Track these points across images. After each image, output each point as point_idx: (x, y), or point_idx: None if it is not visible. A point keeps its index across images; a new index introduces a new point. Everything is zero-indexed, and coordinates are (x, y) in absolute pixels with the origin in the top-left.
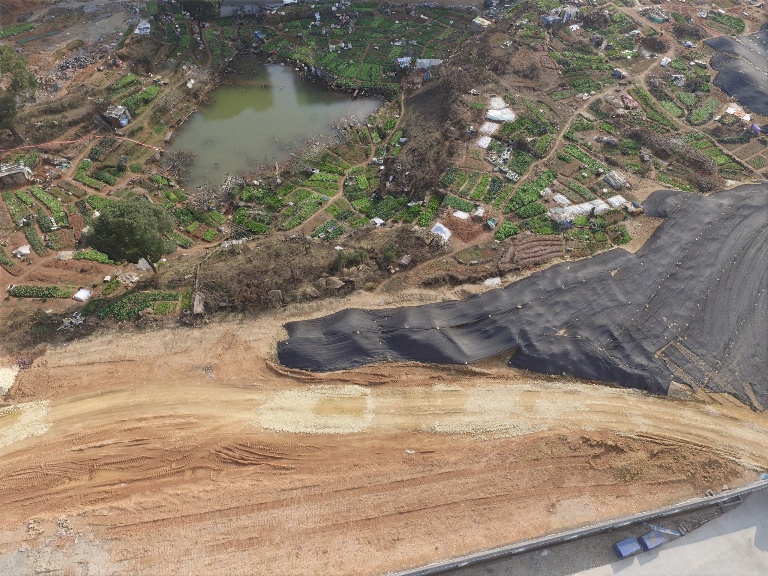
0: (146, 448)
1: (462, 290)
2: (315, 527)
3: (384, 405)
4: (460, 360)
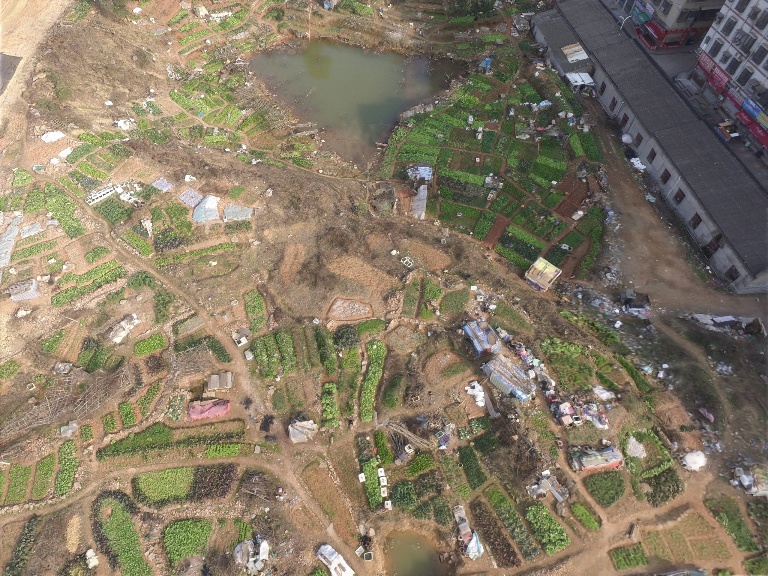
0: None
1: None
2: None
3: None
4: None
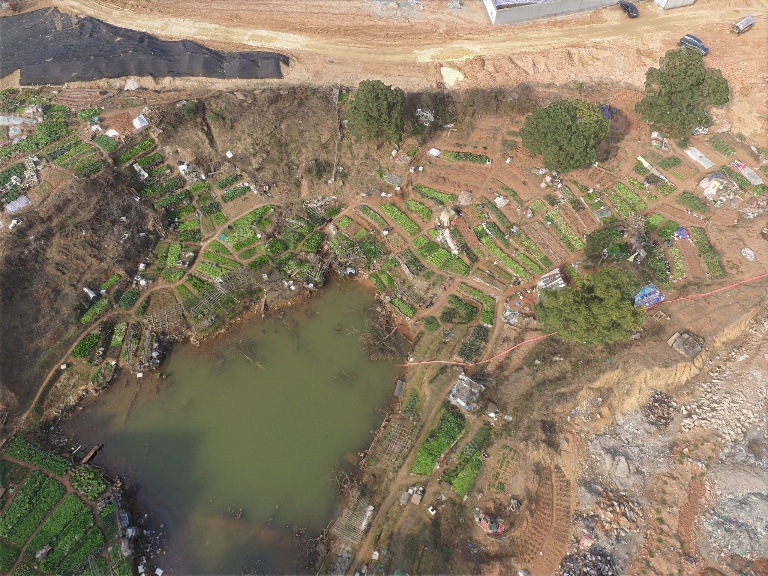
0: (362, 38)
1: (157, 84)
2: (288, 6)
3: (240, 36)
4: (187, 40)
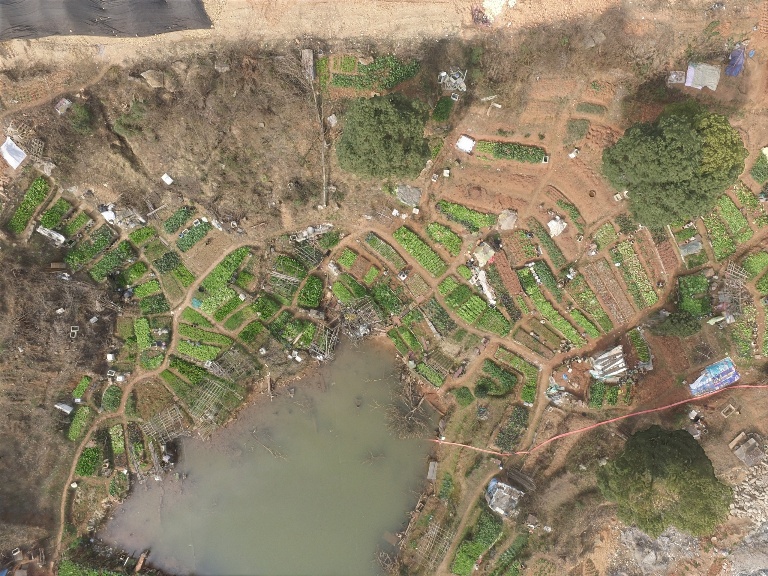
0: None
1: (4, 56)
2: None
3: None
4: None
